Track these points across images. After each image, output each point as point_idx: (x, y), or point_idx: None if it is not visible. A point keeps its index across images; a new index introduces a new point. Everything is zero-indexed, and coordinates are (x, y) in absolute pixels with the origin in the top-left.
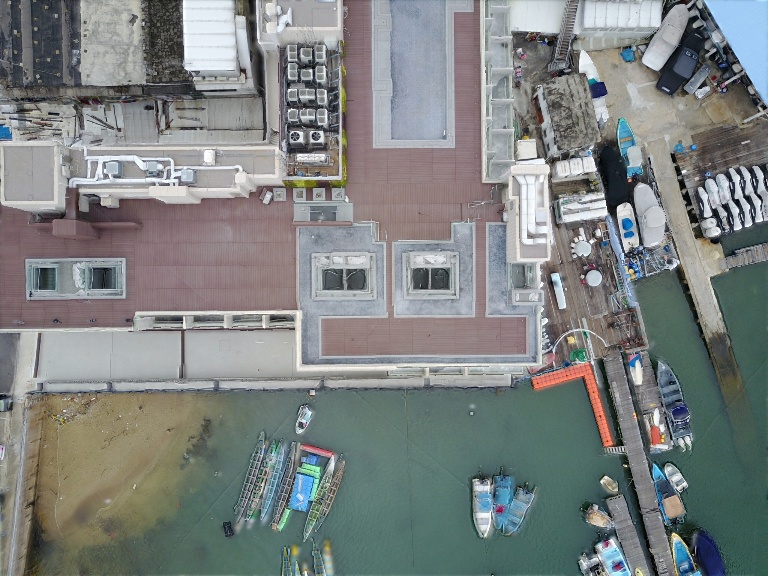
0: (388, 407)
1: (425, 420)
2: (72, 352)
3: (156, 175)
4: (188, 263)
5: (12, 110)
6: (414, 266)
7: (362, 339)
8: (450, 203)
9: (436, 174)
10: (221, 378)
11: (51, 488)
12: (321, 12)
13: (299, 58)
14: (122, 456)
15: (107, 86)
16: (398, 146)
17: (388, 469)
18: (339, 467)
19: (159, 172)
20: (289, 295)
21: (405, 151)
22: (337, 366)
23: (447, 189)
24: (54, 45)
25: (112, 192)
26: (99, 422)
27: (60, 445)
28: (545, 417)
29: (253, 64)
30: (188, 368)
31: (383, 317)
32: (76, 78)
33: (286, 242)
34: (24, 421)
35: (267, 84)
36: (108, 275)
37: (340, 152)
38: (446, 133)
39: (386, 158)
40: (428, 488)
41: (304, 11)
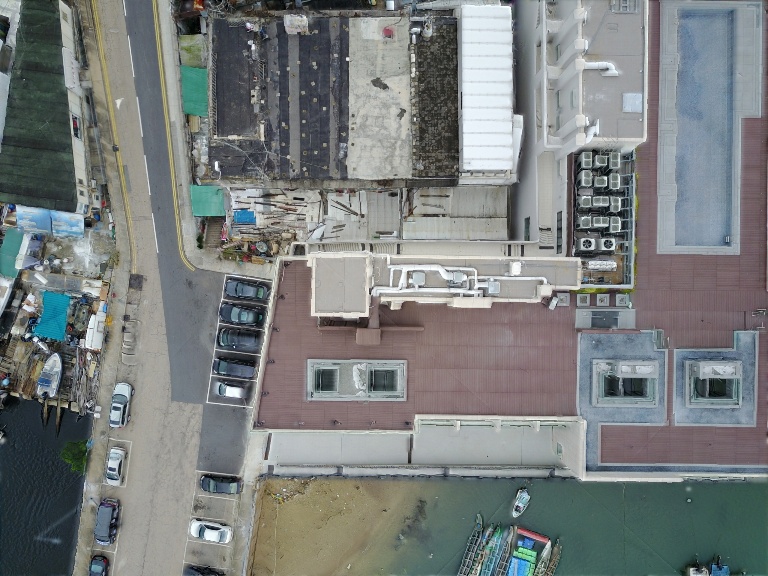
0: (604, 492)
1: (641, 506)
2: (304, 435)
3: (460, 285)
4: (469, 366)
5: (258, 194)
6: (704, 377)
7: (642, 447)
8: (733, 311)
9: (720, 281)
10: (455, 466)
11: (267, 566)
12: (626, 123)
13: (593, 165)
14: (338, 536)
15: (372, 179)
16: (682, 252)
17: (603, 554)
18: (557, 552)
19: (462, 282)
20: (569, 401)
21: (689, 257)
22: (623, 476)
23: (731, 297)
24: (321, 138)
25: (413, 300)
26: (317, 501)
27: (278, 524)
28: (762, 506)
29: (519, 160)
30: (417, 453)
31: (663, 425)
32: (342, 171)
33: (567, 347)
34: (254, 503)
35: (537, 182)
36: (389, 377)
37: (632, 261)
38: (731, 240)
39: (670, 264)
40: (643, 575)
41: (609, 121)
